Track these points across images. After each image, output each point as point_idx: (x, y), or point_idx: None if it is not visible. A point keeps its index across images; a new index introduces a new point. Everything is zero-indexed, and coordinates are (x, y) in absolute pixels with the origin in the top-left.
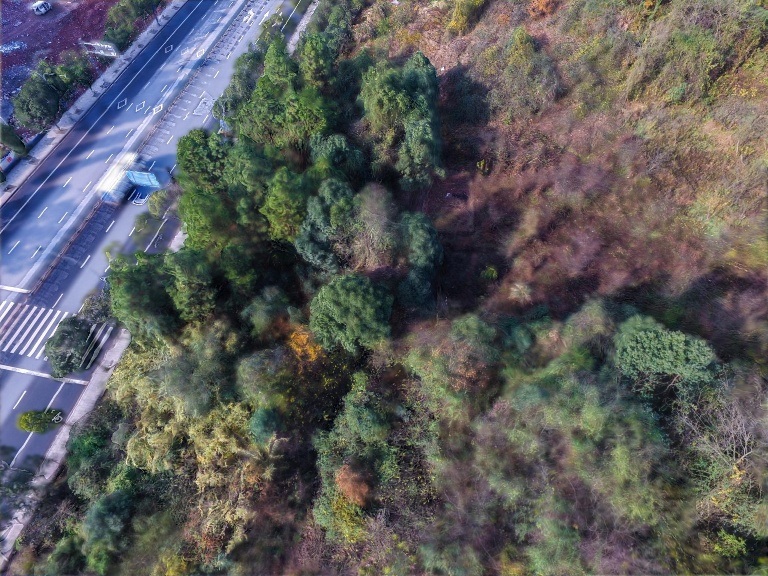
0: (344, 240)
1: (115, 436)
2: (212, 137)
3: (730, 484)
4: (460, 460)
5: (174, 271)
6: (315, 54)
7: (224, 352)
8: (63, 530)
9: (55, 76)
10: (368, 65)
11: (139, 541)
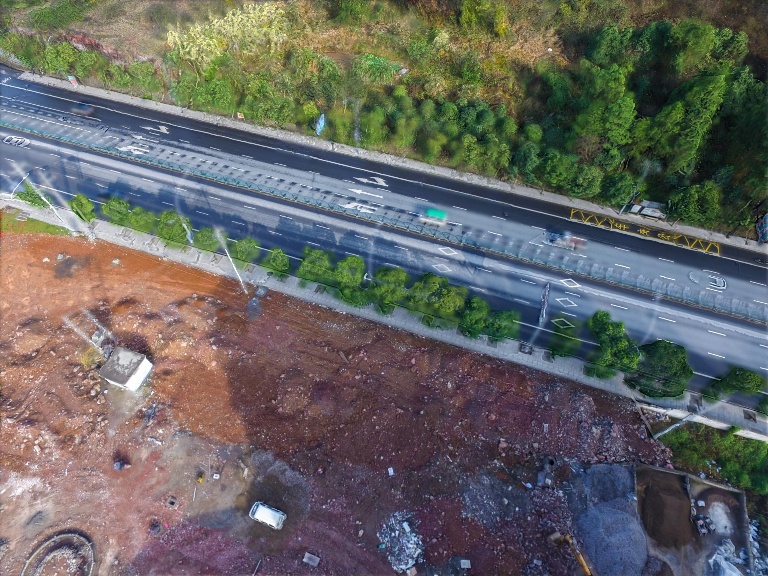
0: None
1: None
2: None
3: None
4: None
5: None
6: None
7: None
8: None
9: None
10: None
11: None
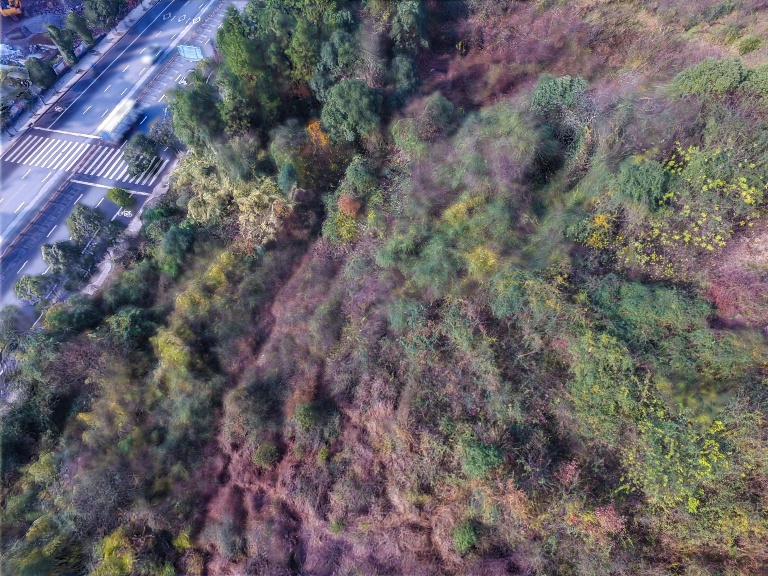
0: (348, 76)
1: (179, 200)
2: (249, 5)
3: (585, 142)
4: (424, 184)
5: (223, 83)
6: None
7: None
8: (144, 254)
9: None
10: None
11: (197, 263)
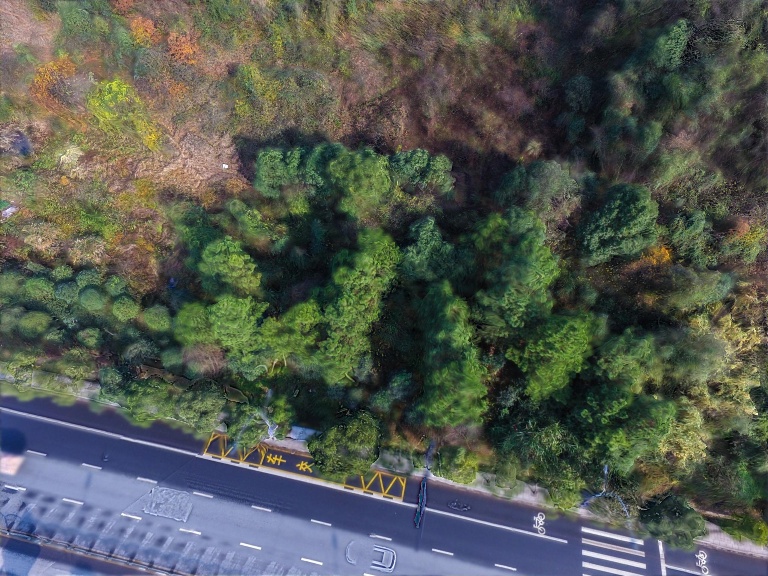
0: None
1: (746, 427)
2: (459, 335)
3: None
4: (716, 165)
5: None
6: None
7: None
8: None
9: None
10: (212, 231)
11: None
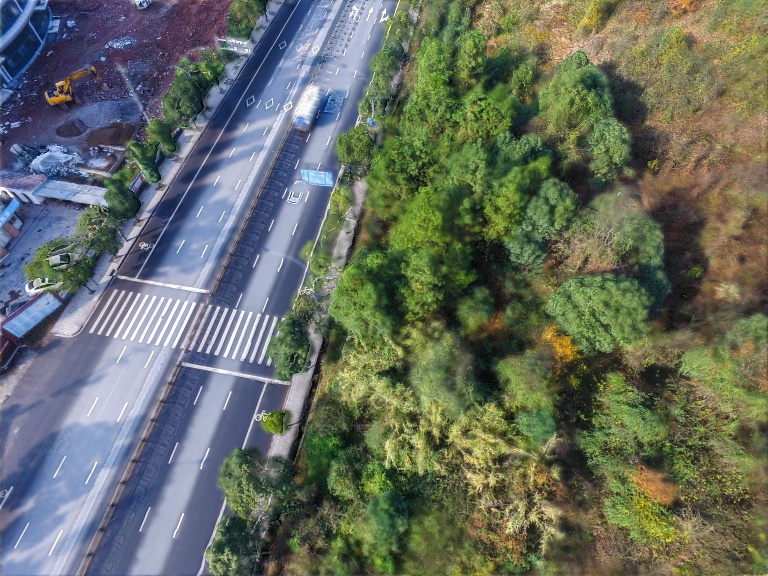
0: (565, 240)
1: (370, 437)
2: (419, 137)
3: None
4: None
5: (423, 272)
6: (476, 52)
7: (446, 352)
8: (337, 531)
9: (198, 73)
10: (511, 63)
11: (412, 541)
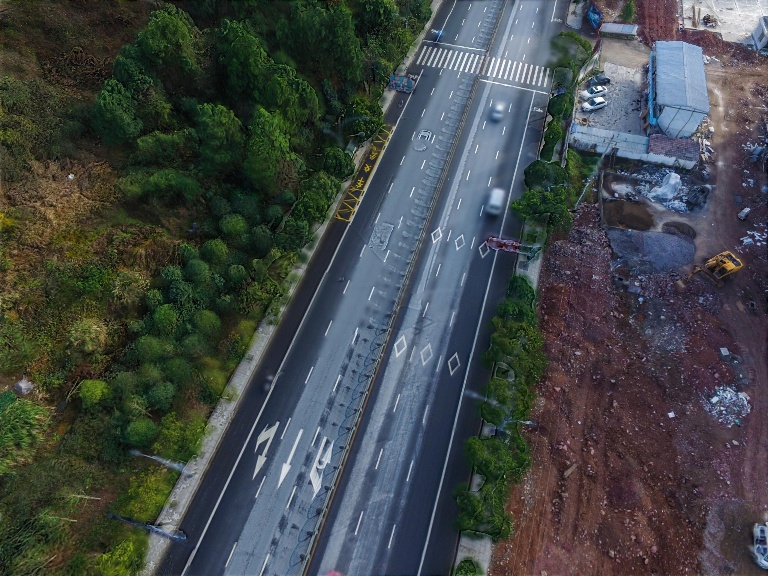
0: None
1: None
2: None
3: None
4: None
5: None
6: None
7: None
8: None
9: None
10: None
11: None
